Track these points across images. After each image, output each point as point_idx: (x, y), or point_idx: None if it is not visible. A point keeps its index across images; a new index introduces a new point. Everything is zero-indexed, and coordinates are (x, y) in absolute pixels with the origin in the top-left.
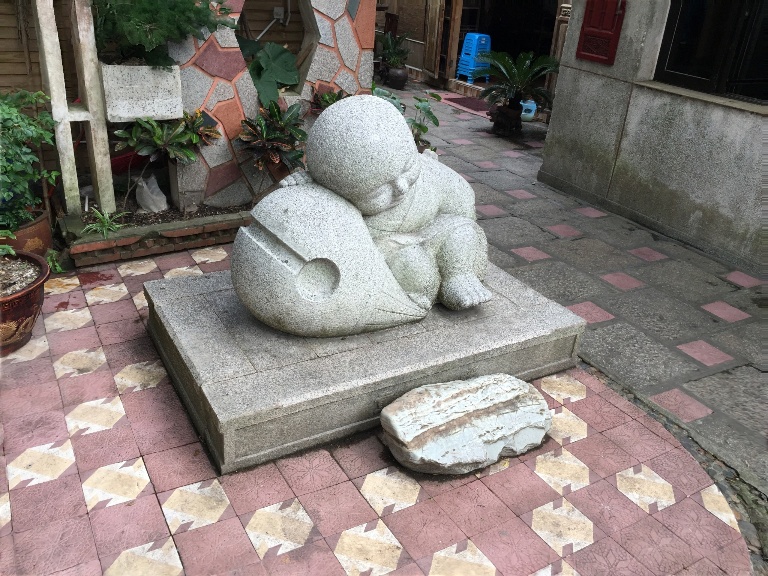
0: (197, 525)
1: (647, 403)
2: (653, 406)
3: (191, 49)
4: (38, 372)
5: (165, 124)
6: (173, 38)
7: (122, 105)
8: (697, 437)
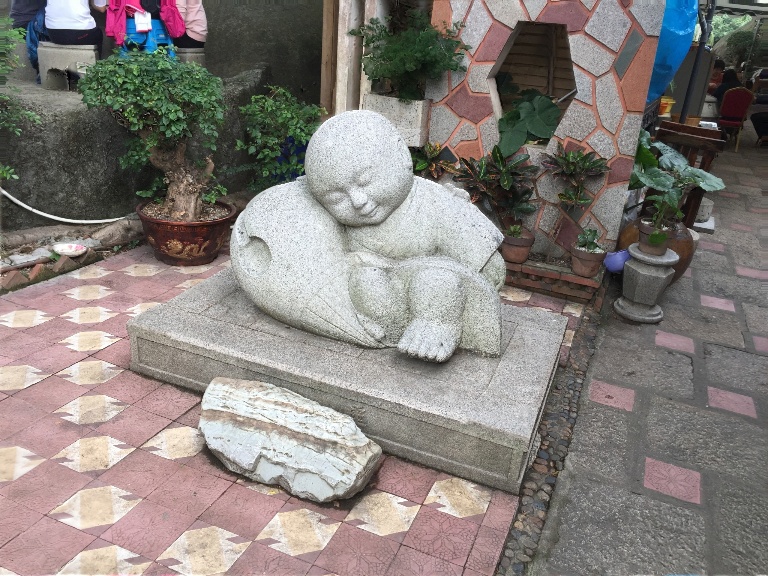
0: (70, 379)
1: (526, 575)
2: None
3: (445, 90)
4: (174, 280)
5: None
6: (416, 76)
7: None
8: None
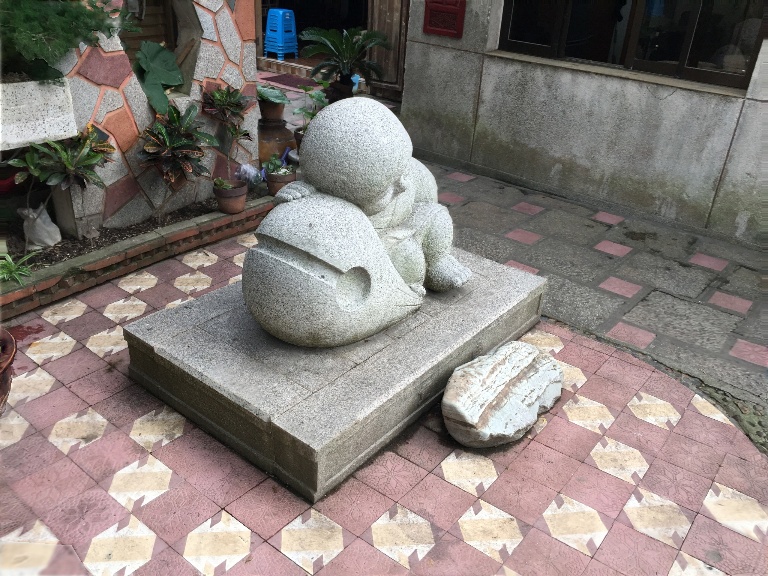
0: (328, 558)
1: (609, 340)
2: (614, 341)
3: (72, 57)
4: (38, 453)
5: None
6: None
7: (9, 130)
8: (660, 359)
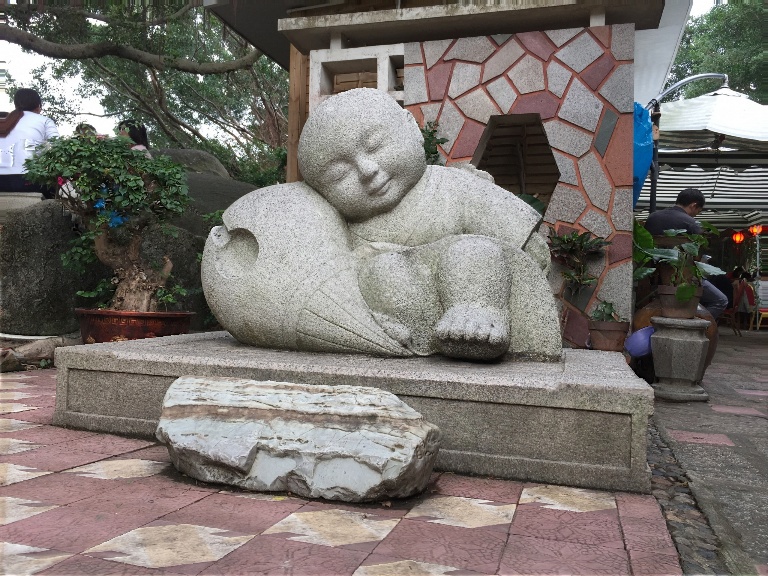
0: None
1: (728, 561)
2: (737, 568)
3: None
4: None
5: None
6: None
7: None
8: None
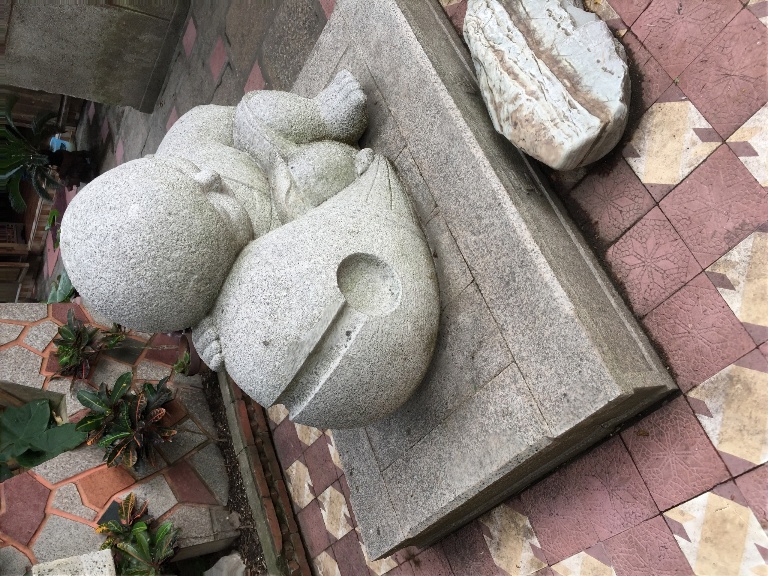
0: None
1: None
2: None
3: (5, 553)
4: None
5: (122, 573)
6: None
7: None
8: None
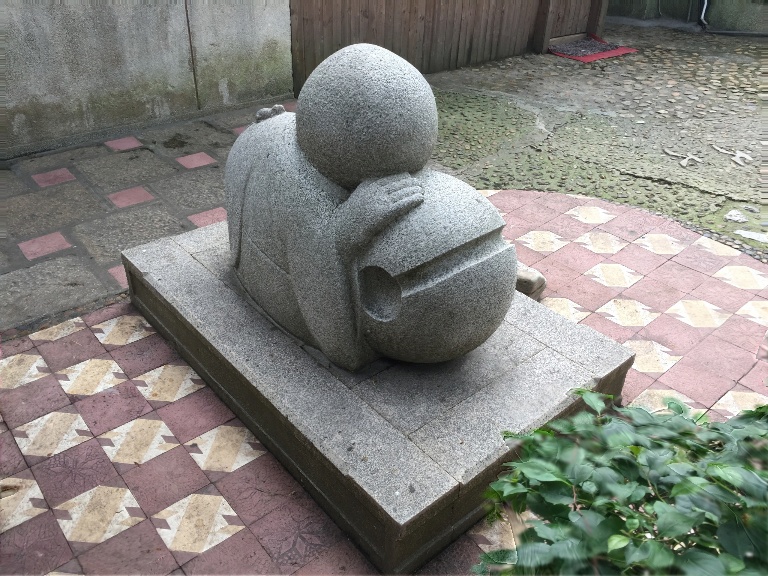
0: (686, 399)
1: None
2: None
3: None
4: None
5: None
6: None
7: None
8: None
